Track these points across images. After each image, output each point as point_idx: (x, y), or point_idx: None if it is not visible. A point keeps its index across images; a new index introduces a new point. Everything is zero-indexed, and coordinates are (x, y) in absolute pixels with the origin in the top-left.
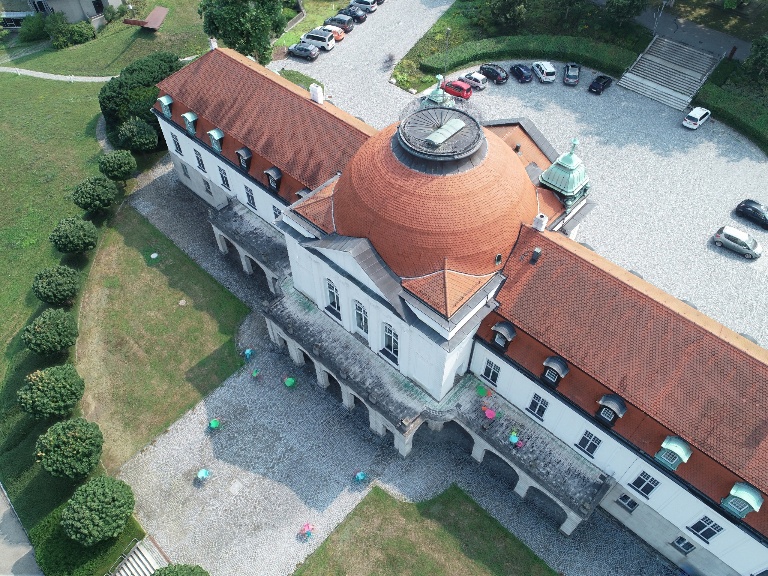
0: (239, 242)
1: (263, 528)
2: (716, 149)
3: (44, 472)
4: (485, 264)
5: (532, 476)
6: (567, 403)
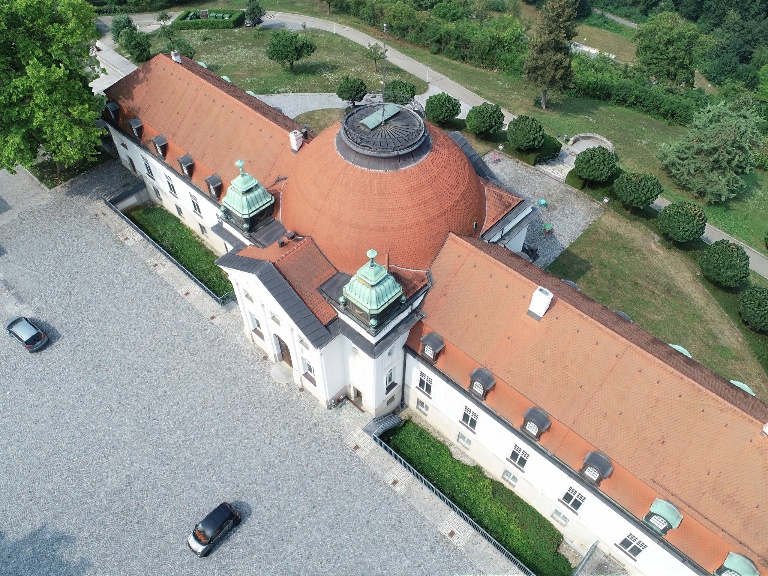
0: None
1: None
2: None
3: None
4: None
5: None
6: None
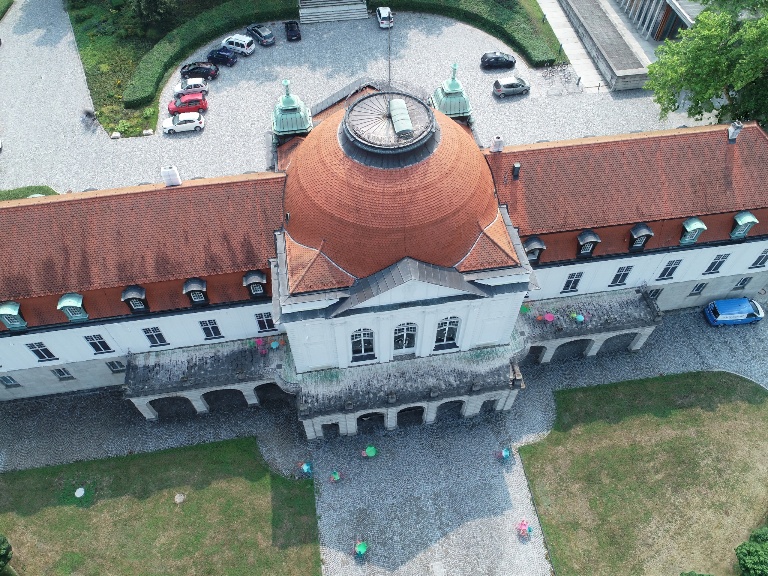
0: (192, 386)
1: (494, 567)
2: (421, 32)
3: None
4: (493, 205)
5: (612, 330)
6: (606, 259)
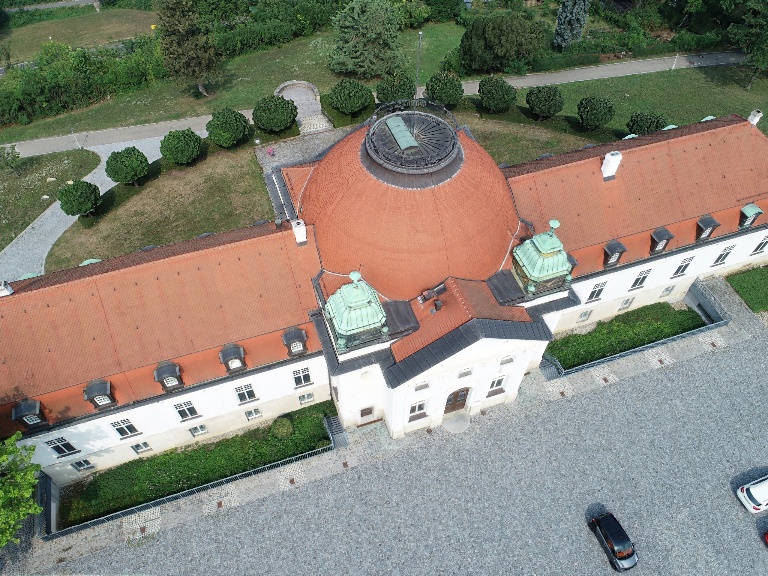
0: None
1: None
2: None
3: None
4: None
5: None
6: None
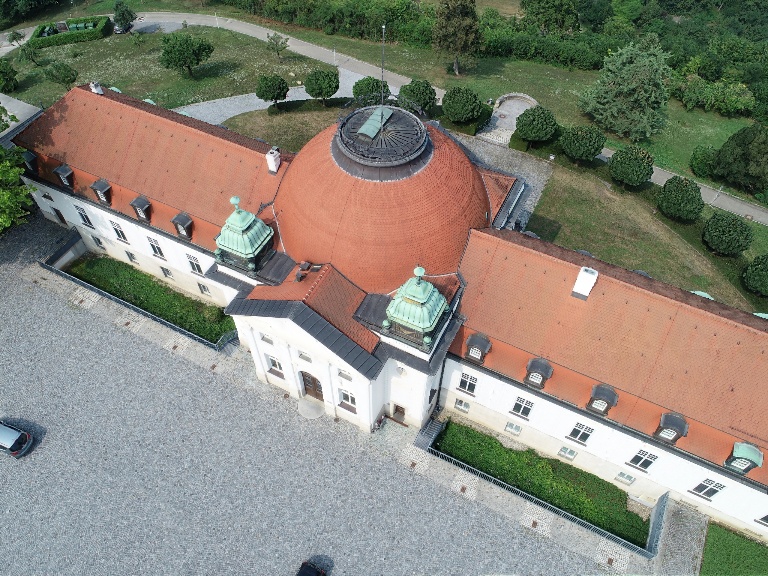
0: None
1: None
2: None
3: (602, 164)
4: None
5: None
6: None
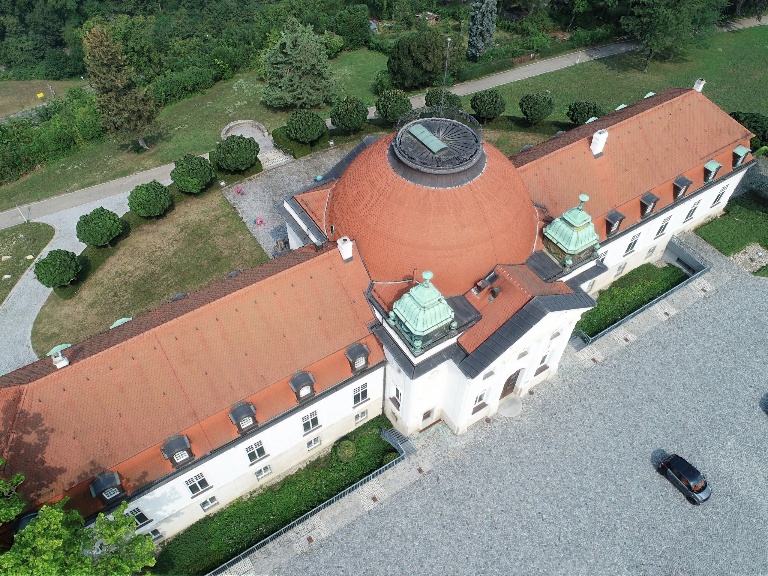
0: None
1: None
2: None
3: None
4: None
5: None
6: None
